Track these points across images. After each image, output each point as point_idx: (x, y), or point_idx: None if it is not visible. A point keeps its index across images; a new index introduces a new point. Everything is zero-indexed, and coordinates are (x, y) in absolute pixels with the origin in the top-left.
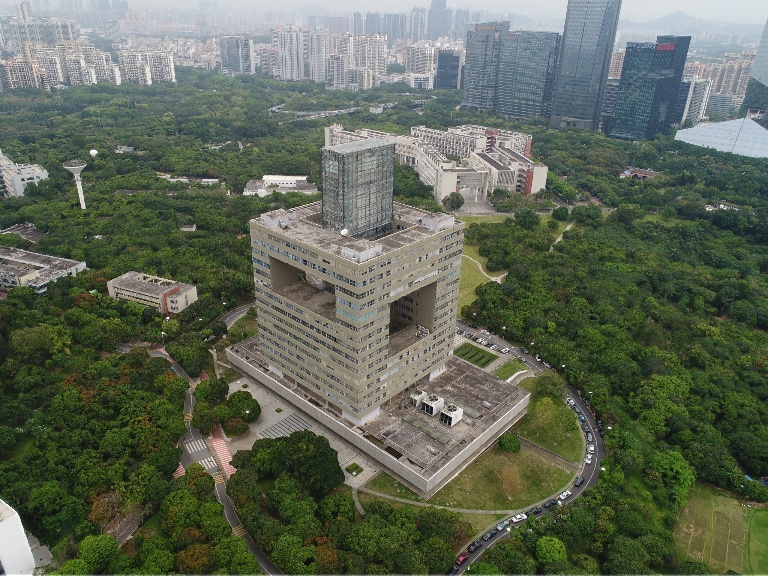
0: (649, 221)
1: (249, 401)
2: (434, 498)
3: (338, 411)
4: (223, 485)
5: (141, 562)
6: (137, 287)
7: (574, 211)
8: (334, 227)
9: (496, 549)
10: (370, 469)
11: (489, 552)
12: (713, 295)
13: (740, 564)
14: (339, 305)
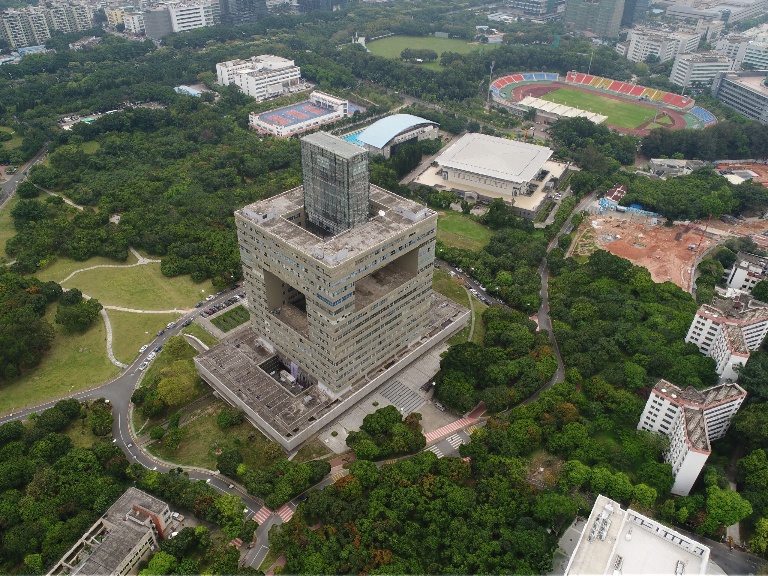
0: (83, 155)
1: (387, 409)
2: (466, 321)
3: (403, 350)
4: (479, 425)
5: (572, 448)
6: (100, 573)
7: (43, 179)
8: (361, 220)
9: (513, 294)
10: (444, 348)
11: (514, 298)
12: (235, 169)
13: (473, 241)
14: (421, 258)
